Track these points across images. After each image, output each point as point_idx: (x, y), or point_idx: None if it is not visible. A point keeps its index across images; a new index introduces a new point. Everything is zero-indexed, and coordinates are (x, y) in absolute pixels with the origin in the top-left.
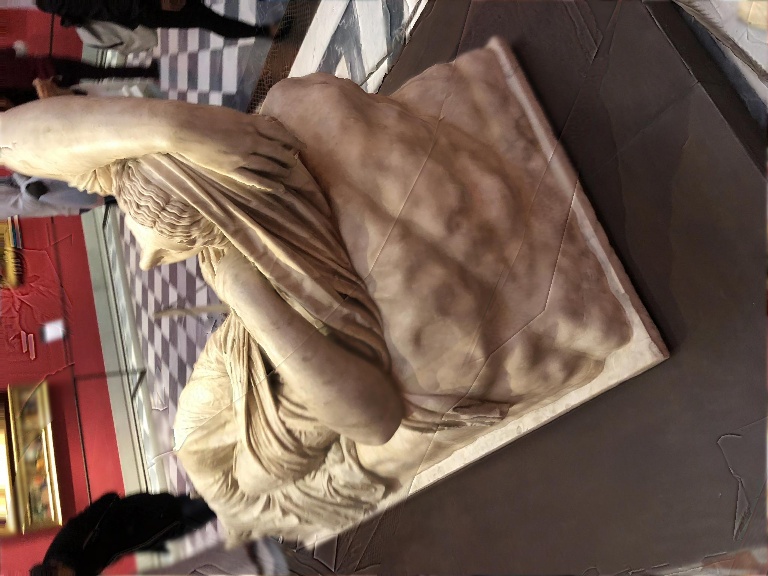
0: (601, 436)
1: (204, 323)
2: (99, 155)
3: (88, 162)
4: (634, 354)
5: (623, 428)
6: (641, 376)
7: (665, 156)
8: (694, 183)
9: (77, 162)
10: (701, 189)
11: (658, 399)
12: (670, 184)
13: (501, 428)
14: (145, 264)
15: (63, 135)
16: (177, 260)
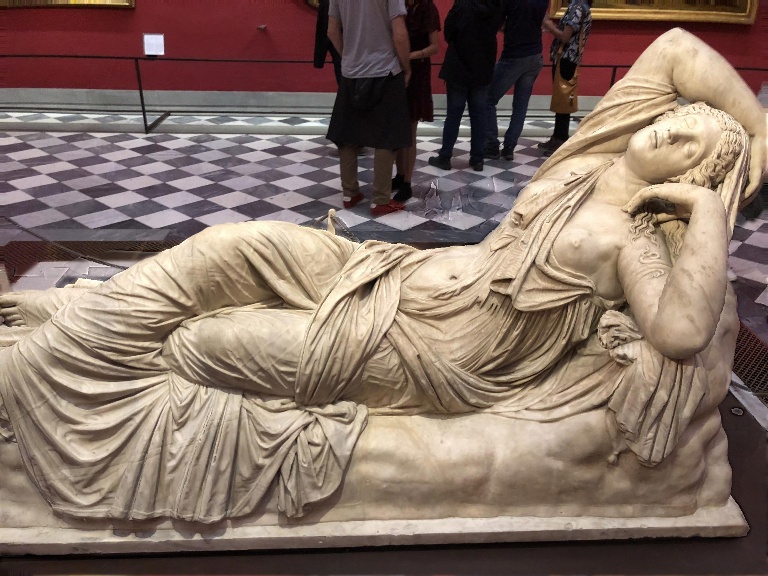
0: (647, 575)
1: (33, 263)
2: (735, 93)
3: (724, 88)
4: (727, 515)
5: (677, 575)
6: (708, 543)
7: (741, 447)
8: (761, 467)
9: (721, 81)
10: (767, 471)
11: (719, 566)
12: (744, 459)
13: (543, 517)
14: (680, 132)
15: (734, 73)
16: (660, 155)
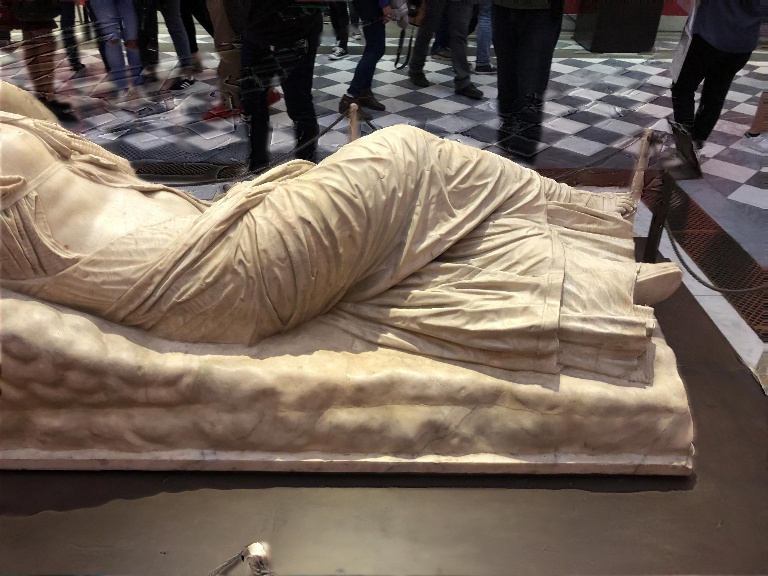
0: None
1: None
2: None
3: None
4: None
5: None
6: None
7: None
8: None
9: None
10: None
11: None
12: None
13: None
14: None
15: None
16: None
